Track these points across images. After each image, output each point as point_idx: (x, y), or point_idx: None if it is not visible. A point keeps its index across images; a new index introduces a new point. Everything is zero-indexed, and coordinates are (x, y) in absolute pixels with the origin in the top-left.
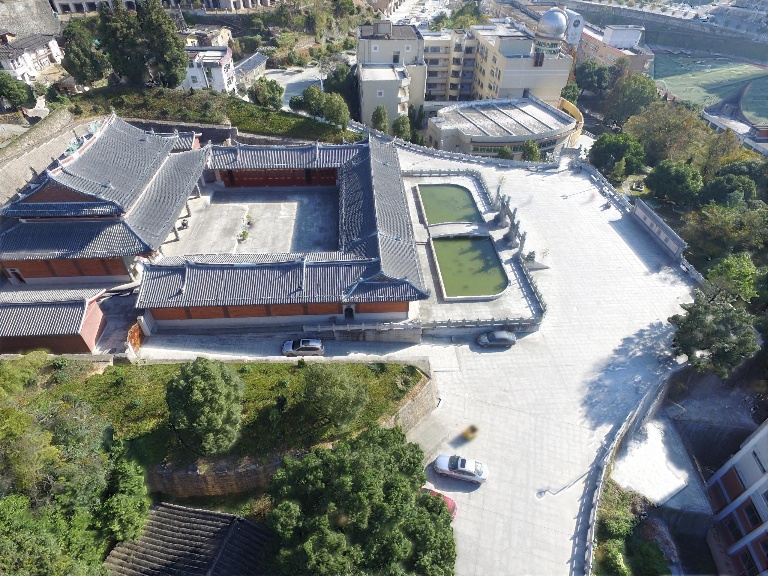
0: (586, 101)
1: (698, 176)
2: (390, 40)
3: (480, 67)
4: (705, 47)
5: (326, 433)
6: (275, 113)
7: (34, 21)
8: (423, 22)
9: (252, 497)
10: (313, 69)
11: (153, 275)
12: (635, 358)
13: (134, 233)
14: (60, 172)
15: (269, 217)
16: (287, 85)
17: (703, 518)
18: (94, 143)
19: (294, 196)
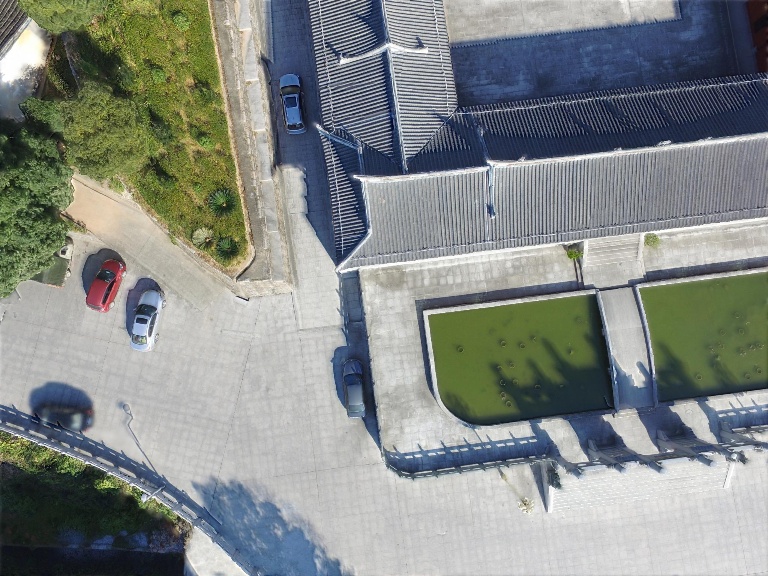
0: None
1: None
2: None
3: None
4: None
5: None
6: None
7: None
8: None
9: (75, 87)
10: None
11: None
12: None
13: None
14: None
15: None
16: None
17: None
18: None
19: (705, 7)
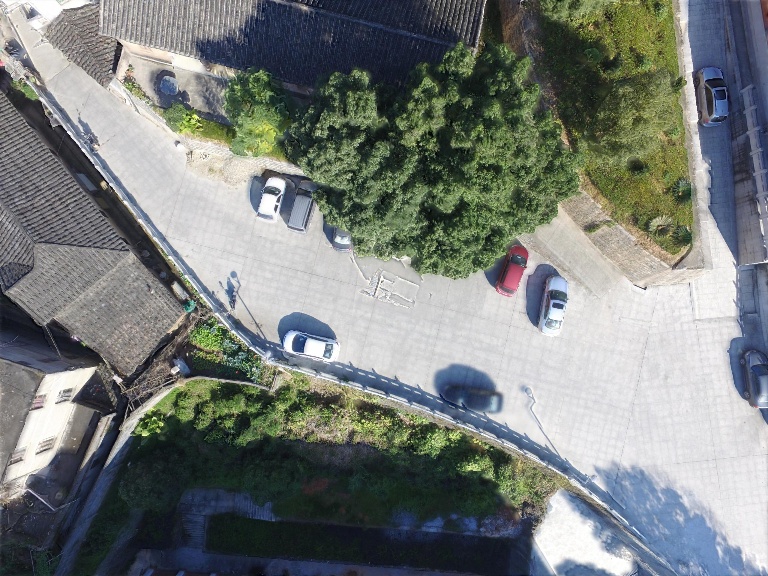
0: None
1: None
2: None
3: None
4: None
5: (579, 133)
6: None
7: None
8: None
9: None
10: None
11: None
12: None
13: None
14: None
15: None
16: None
17: None
18: None
19: None
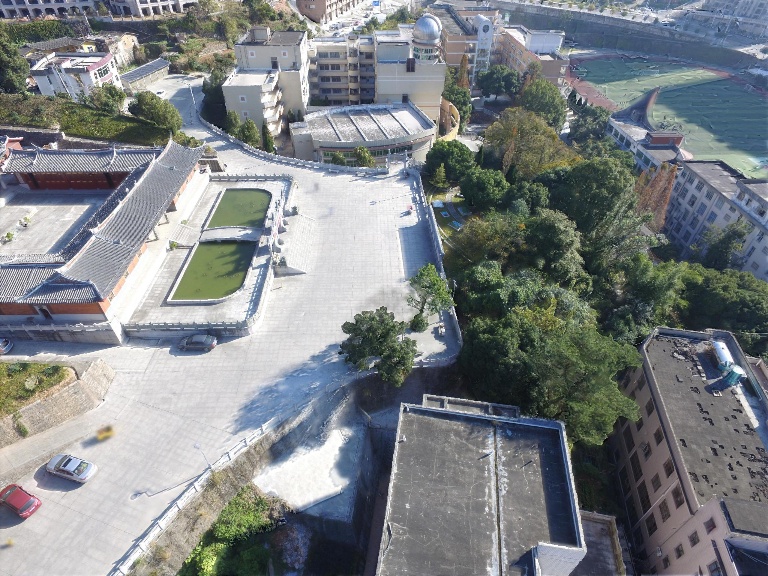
0: (500, 106)
1: (503, 183)
2: (265, 46)
3: None
4: (663, 51)
5: None
6: (108, 118)
7: None
8: (360, 27)
9: None
10: None
11: None
12: (327, 364)
13: None
14: None
15: (51, 219)
16: (179, 90)
17: (343, 526)
18: None
19: (91, 199)
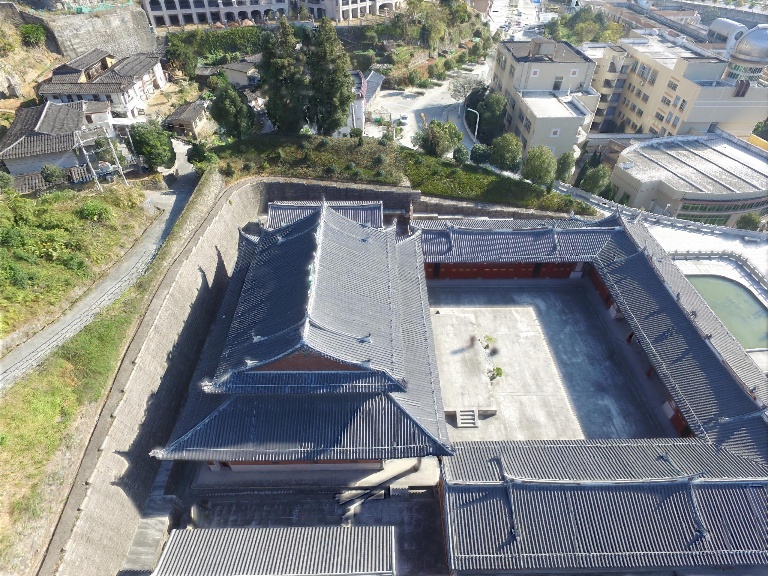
0: None
1: None
2: (555, 63)
3: (638, 91)
4: None
5: None
6: (460, 169)
7: (130, 37)
8: None
9: None
10: (434, 90)
11: (459, 500)
12: None
13: (408, 415)
14: (308, 327)
15: (508, 334)
16: (414, 112)
17: None
18: (319, 257)
19: (522, 296)
